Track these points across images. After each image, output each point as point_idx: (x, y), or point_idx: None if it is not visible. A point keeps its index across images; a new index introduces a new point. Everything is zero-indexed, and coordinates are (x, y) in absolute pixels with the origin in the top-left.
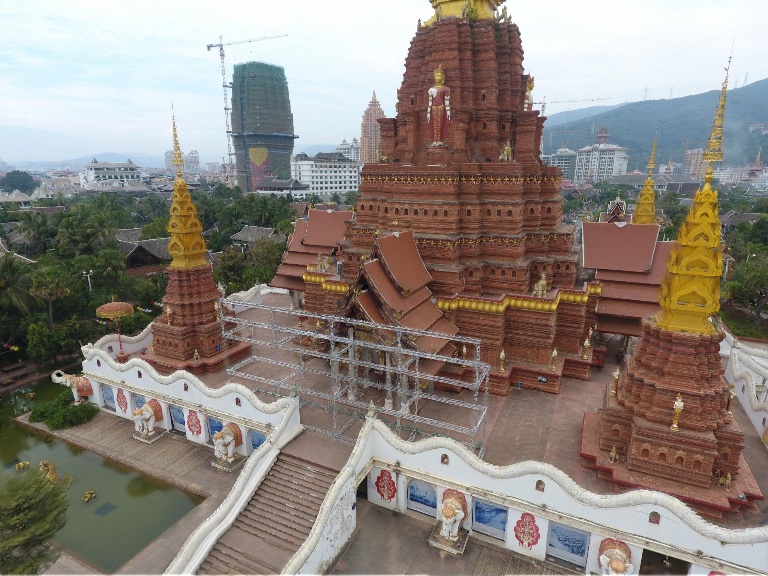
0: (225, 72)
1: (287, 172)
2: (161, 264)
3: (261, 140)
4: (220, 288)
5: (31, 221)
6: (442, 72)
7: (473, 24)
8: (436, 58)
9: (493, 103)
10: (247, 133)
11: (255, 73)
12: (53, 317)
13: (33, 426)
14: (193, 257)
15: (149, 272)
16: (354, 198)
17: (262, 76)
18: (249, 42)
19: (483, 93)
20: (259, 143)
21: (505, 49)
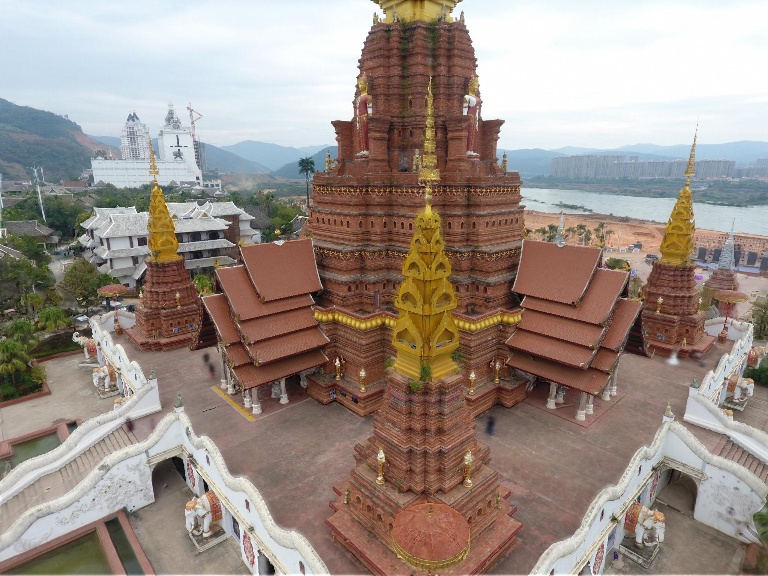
0: None
1: None
2: None
3: None
4: None
5: None
6: None
7: None
8: None
9: None
10: None
11: None
12: None
13: None
14: None
15: None
16: None
17: None
18: None
19: None
20: None
21: None
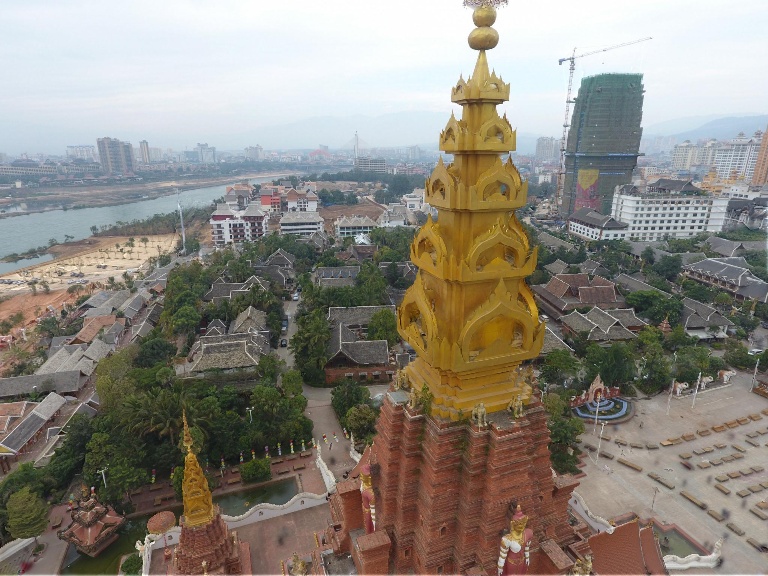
0: (571, 87)
1: (608, 205)
2: (358, 367)
3: (593, 161)
4: (351, 439)
5: (313, 290)
6: (364, 475)
7: (426, 417)
8: (377, 441)
9: (427, 543)
10: (579, 154)
11: (602, 87)
12: (212, 447)
13: (118, 575)
14: (194, 516)
15: (347, 372)
16: (671, 259)
17: (610, 89)
18: (603, 51)
19: (421, 518)
20: (590, 165)
21: (468, 467)
